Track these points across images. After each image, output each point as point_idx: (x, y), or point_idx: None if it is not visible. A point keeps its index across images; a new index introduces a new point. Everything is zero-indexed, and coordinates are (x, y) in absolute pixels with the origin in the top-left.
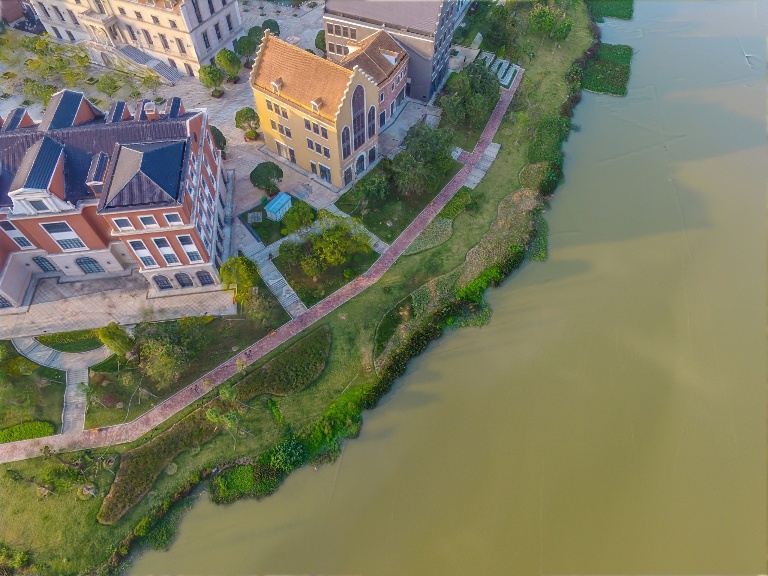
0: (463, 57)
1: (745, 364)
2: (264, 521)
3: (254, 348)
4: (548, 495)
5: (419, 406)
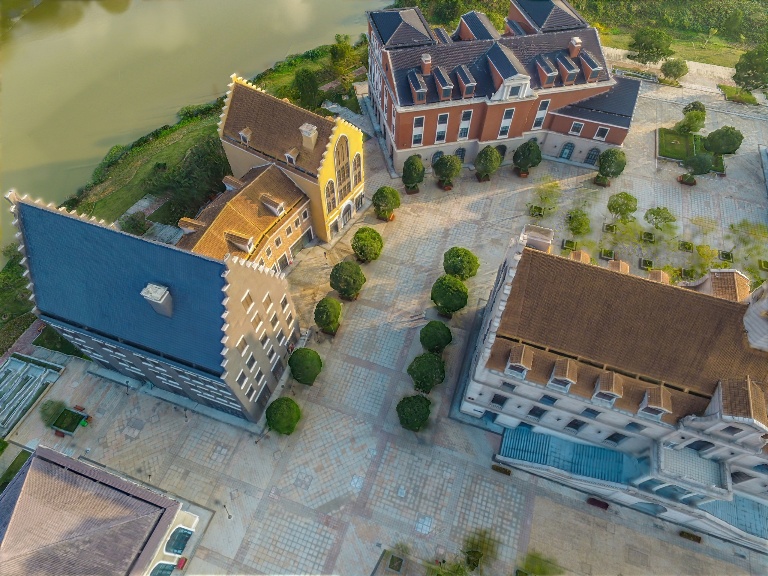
0: (52, 413)
1: (22, 94)
2: (321, 41)
3: (340, 83)
4: (183, 50)
5: (241, 73)
